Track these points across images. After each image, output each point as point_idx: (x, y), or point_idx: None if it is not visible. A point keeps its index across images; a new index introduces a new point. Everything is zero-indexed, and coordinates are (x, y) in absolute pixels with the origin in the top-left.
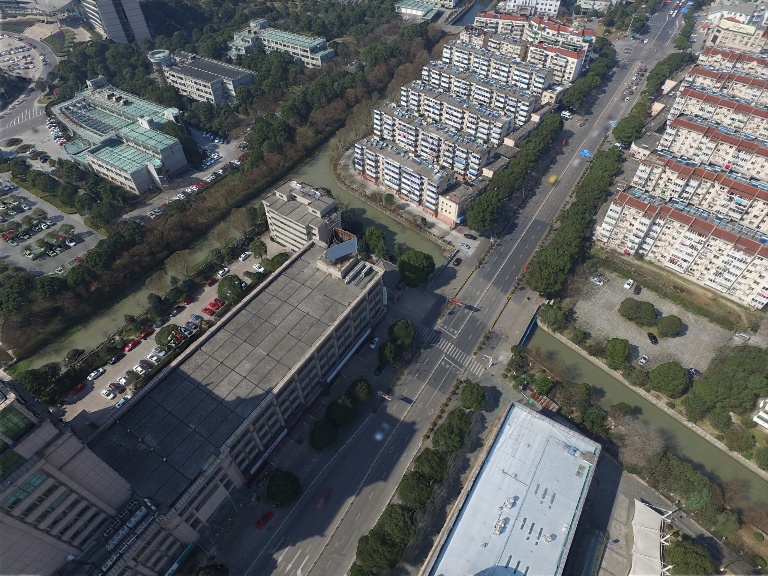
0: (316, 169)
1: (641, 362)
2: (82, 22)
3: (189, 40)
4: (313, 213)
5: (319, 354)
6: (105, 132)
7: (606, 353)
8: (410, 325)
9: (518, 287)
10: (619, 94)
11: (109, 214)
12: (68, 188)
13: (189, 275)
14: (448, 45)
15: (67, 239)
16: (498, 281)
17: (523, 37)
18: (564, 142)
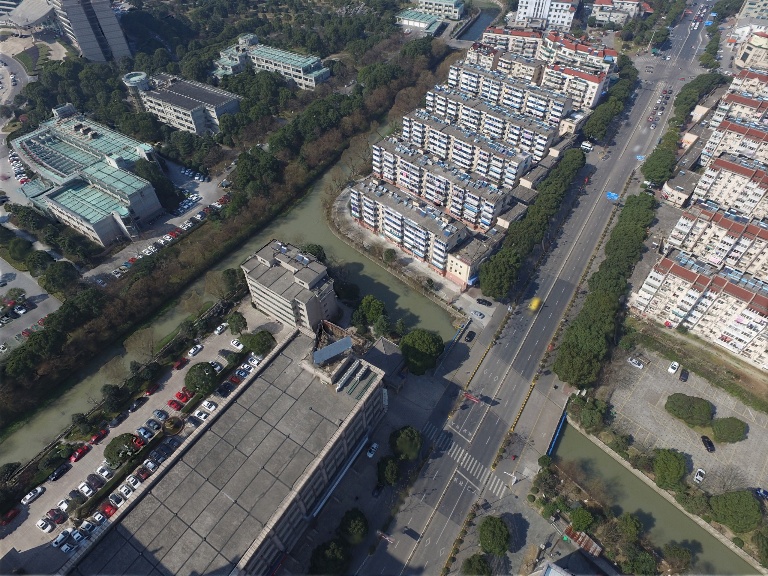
0: (307, 212)
1: (697, 479)
2: (59, 36)
3: (172, 57)
4: (300, 284)
5: (302, 494)
6: (68, 172)
7: (655, 470)
8: (416, 436)
9: (542, 371)
10: (643, 121)
11: (64, 277)
12: (20, 243)
13: (156, 352)
14: (455, 66)
15: (16, 305)
16: (518, 362)
17: (536, 55)
18: (586, 180)
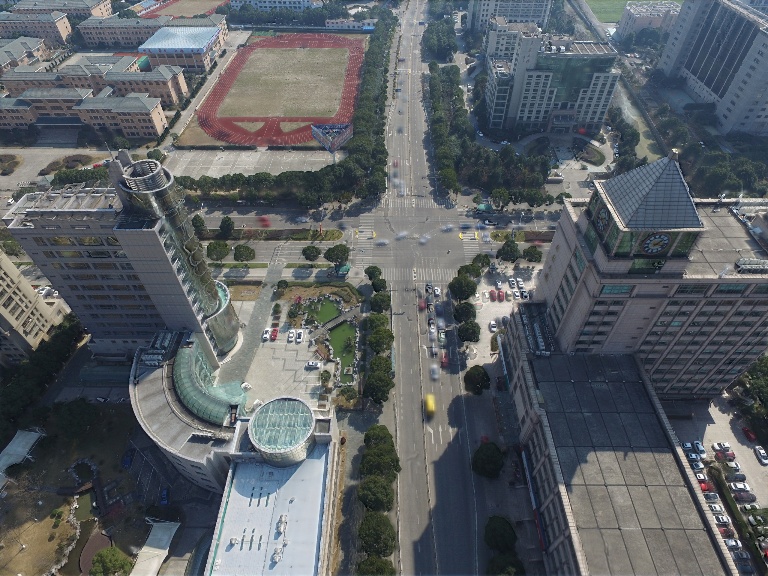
0: None
1: None
2: None
3: None
4: None
5: None
6: None
7: None
8: None
9: None
10: None
11: None
12: None
13: None
14: None
15: None
16: None
17: None
18: None
